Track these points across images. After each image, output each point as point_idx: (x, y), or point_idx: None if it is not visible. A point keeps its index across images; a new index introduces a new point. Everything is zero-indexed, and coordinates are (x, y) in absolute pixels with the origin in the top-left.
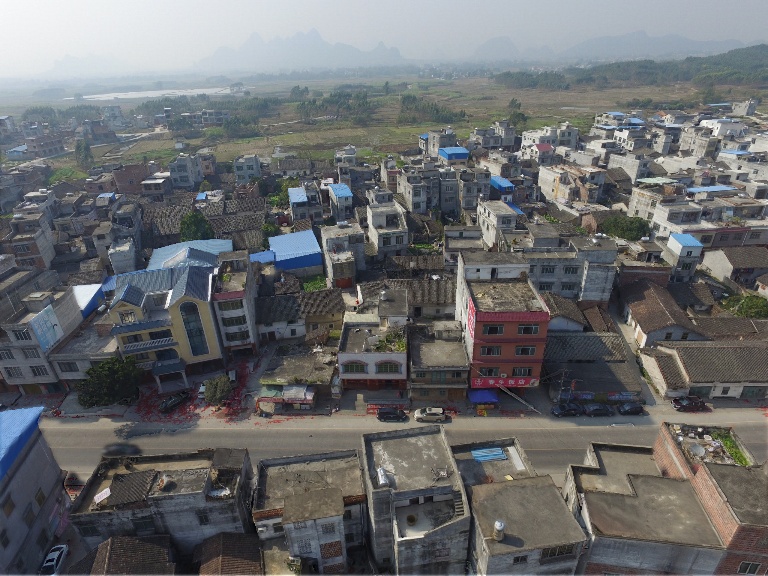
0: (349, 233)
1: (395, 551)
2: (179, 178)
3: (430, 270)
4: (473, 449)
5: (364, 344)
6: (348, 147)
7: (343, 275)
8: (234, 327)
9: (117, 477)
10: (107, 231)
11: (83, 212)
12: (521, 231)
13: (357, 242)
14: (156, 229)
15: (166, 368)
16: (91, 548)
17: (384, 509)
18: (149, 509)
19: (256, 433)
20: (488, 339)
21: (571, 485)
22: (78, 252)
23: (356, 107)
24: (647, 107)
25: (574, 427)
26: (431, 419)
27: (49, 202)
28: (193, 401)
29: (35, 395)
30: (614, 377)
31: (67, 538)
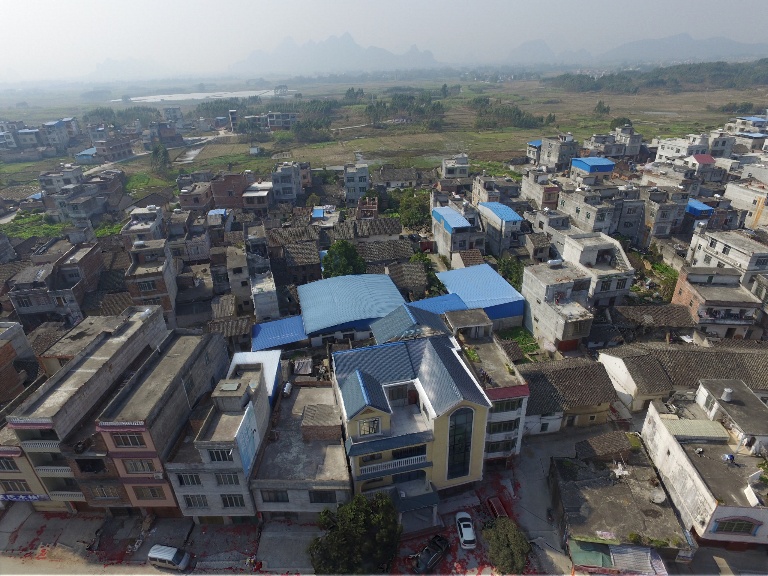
0: (572, 277)
1: None
2: (282, 190)
3: (675, 328)
4: None
5: None
6: (460, 155)
7: (575, 336)
8: (500, 434)
9: None
10: (244, 263)
11: (194, 233)
12: None
13: (580, 289)
14: (290, 258)
15: (416, 501)
16: None
17: None
18: None
19: None
20: None
21: None
22: (203, 287)
23: (430, 110)
24: (747, 112)
25: None
26: None
27: (158, 221)
28: (454, 553)
29: (214, 526)
30: None
31: None
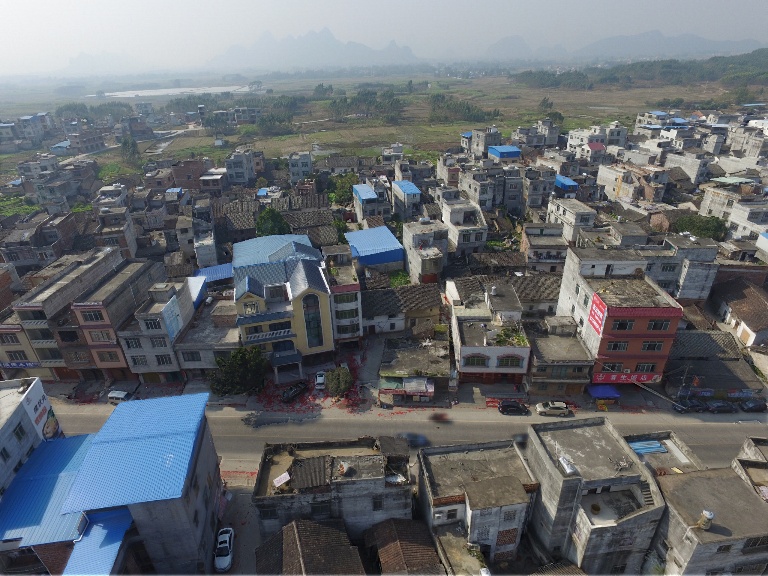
0: (434, 229)
1: (577, 539)
2: (235, 174)
3: (512, 267)
4: (630, 441)
5: (485, 338)
6: (396, 145)
7: (431, 271)
8: (346, 320)
9: (296, 462)
10: (189, 225)
11: (154, 207)
12: (601, 229)
13: (441, 238)
14: (230, 224)
15: (285, 359)
16: (266, 531)
17: (569, 497)
18: (330, 493)
19: (383, 424)
20: (617, 334)
21: (743, 478)
22: (158, 246)
23: (387, 105)
24: (679, 107)
25: (700, 423)
26: (554, 413)
27: (123, 196)
28: (311, 392)
29: (154, 384)
30: (732, 374)
31: (228, 521)
